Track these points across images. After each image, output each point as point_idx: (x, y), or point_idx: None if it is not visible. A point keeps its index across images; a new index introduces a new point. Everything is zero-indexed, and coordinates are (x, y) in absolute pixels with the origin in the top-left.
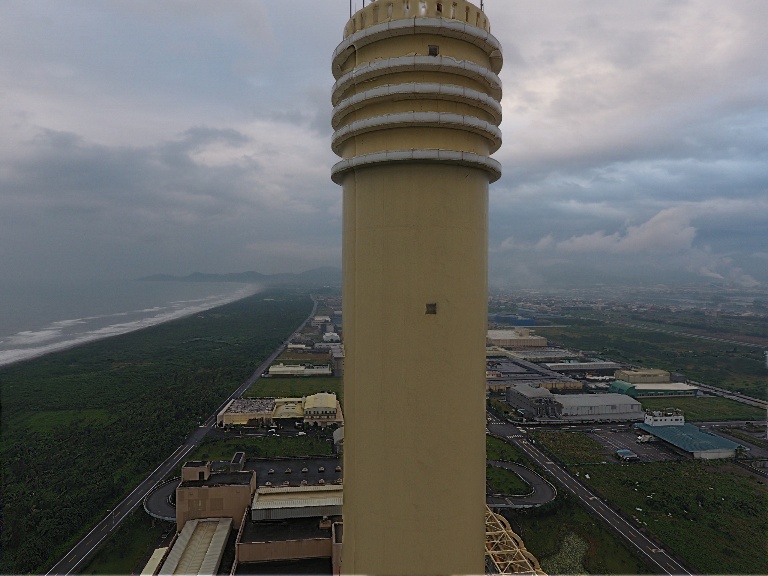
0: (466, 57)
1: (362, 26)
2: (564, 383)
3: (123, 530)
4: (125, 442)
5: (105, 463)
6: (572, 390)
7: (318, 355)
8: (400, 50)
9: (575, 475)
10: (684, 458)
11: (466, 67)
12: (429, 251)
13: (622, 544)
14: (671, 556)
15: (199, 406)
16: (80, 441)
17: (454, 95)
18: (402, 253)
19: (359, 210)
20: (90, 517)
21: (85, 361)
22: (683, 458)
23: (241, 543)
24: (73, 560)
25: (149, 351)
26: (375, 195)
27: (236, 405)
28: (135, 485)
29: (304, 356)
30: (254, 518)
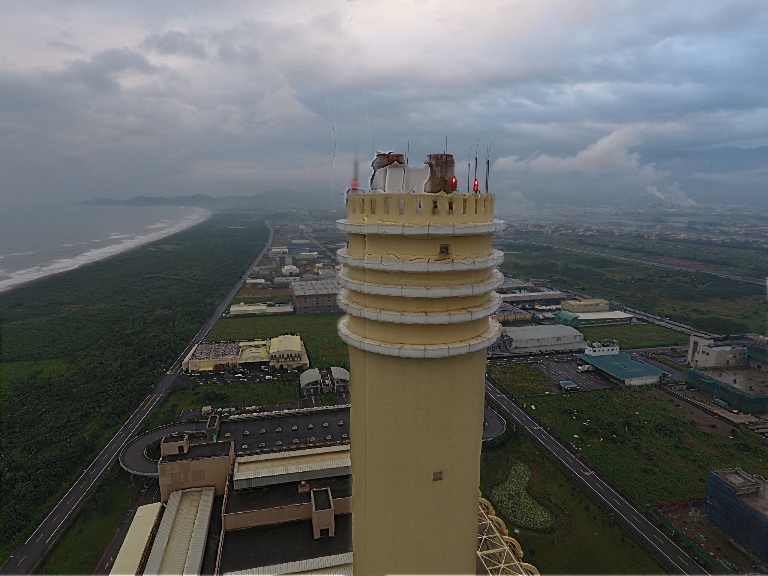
0: (474, 248)
1: (372, 211)
2: (515, 315)
3: (103, 488)
4: (90, 396)
5: (73, 419)
6: (522, 321)
7: (278, 290)
8: (412, 249)
9: (522, 406)
10: (616, 385)
11: (475, 267)
12: (437, 429)
13: (560, 470)
14: (600, 477)
15: (162, 352)
16: (42, 396)
17: (464, 296)
18: (412, 431)
19: (370, 383)
20: (66, 476)
21: (32, 305)
22: (616, 386)
23: (227, 514)
24: (56, 520)
25: (100, 291)
26: (386, 376)
27: (200, 351)
28: (107, 440)
29: (264, 292)
30: (236, 487)
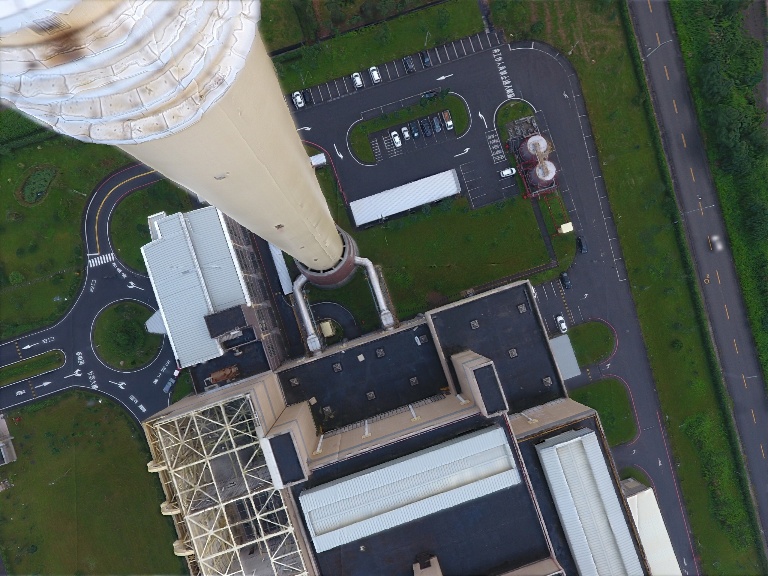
0: None
1: None
2: None
3: None
4: None
5: None
6: None
7: None
8: None
9: None
10: None
11: None
12: None
13: None
14: None
15: None
16: None
17: None
18: None
19: None
20: None
21: None
22: None
23: (558, 572)
24: None
25: None
26: None
27: None
28: None
29: None
30: None
